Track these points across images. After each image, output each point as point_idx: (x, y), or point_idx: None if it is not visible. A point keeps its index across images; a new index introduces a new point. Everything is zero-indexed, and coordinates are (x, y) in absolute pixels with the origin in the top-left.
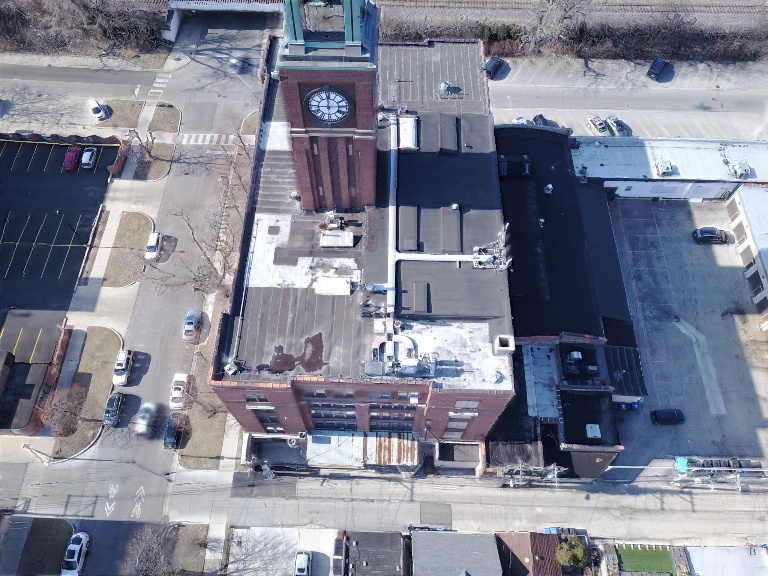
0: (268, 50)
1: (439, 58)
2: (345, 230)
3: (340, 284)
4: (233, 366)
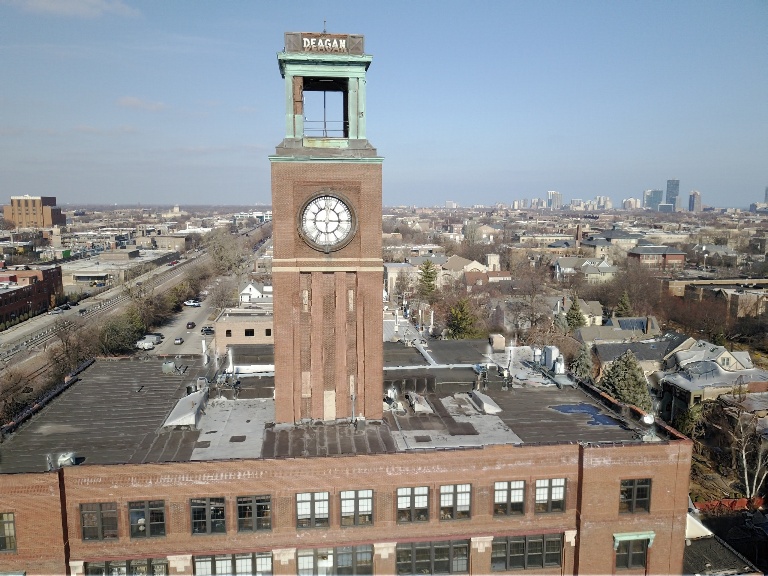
0: None
1: (105, 377)
2: (402, 403)
3: (483, 395)
4: (651, 431)
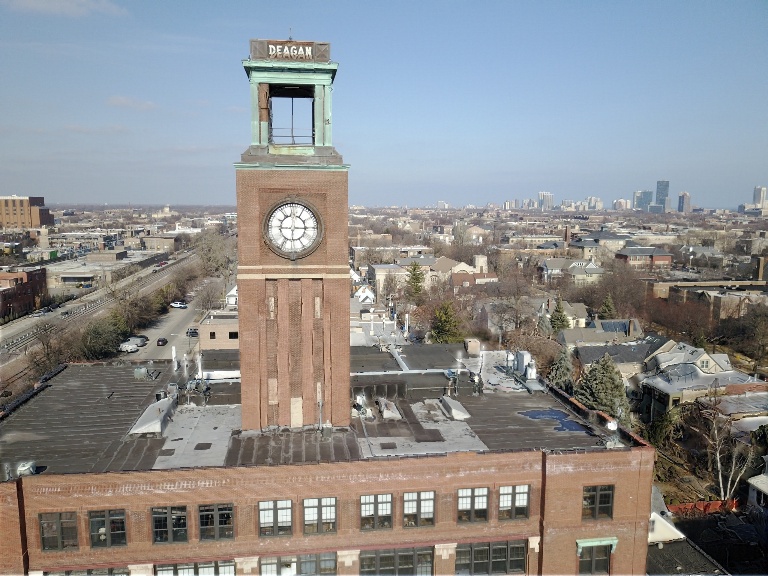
0: None
1: (76, 383)
2: (372, 409)
3: (452, 401)
4: (614, 437)
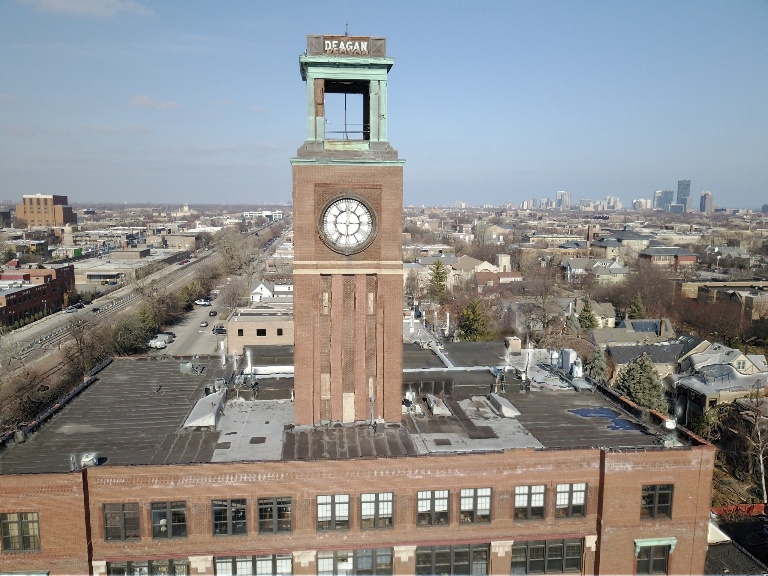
0: (0, 475)
1: (124, 377)
2: (420, 405)
3: (501, 398)
4: (672, 436)
